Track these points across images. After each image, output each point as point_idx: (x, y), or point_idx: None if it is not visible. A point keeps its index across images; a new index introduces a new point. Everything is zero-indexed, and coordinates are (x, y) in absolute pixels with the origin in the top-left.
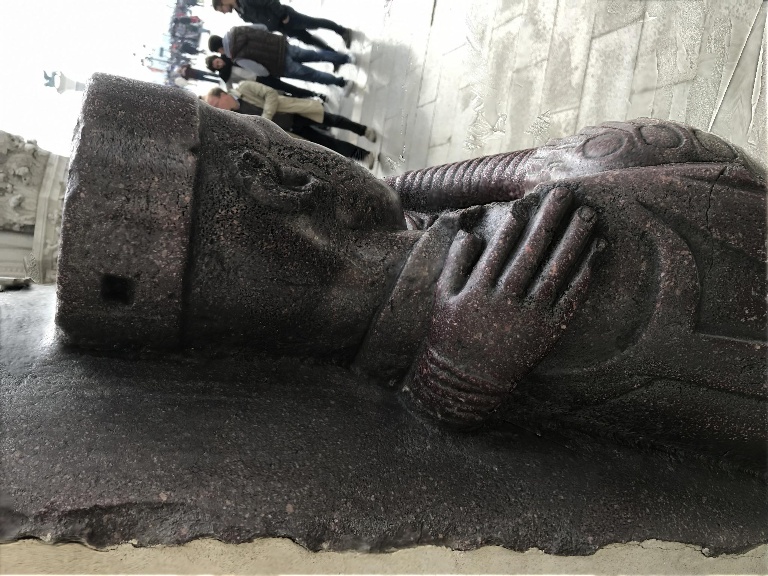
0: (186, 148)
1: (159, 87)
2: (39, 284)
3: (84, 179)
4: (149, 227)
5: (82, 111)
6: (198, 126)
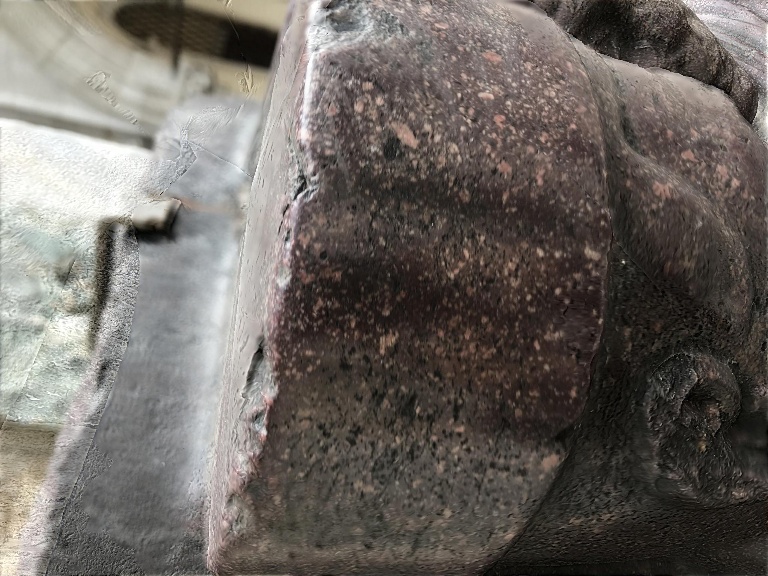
0: (545, 436)
1: (505, 146)
2: (194, 227)
3: (269, 527)
4: (406, 572)
5: (273, 337)
6: (594, 351)
